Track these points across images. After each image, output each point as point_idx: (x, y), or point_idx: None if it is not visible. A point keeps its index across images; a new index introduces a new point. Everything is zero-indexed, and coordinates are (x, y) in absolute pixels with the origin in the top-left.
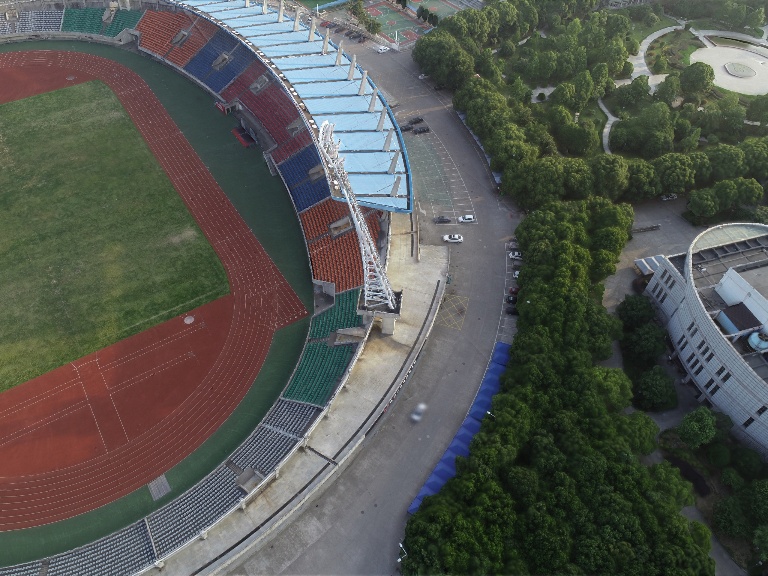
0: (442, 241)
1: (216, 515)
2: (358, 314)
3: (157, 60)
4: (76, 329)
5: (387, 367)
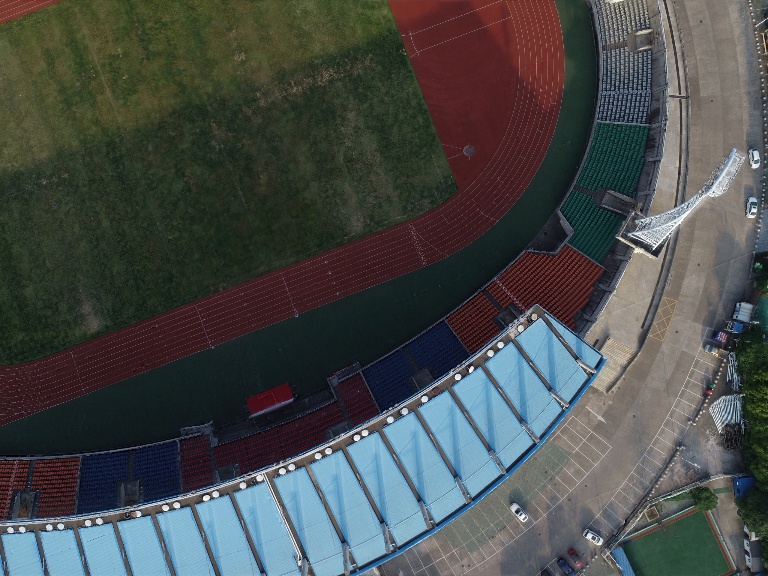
0: None
1: None
2: None
3: None
4: None
5: None
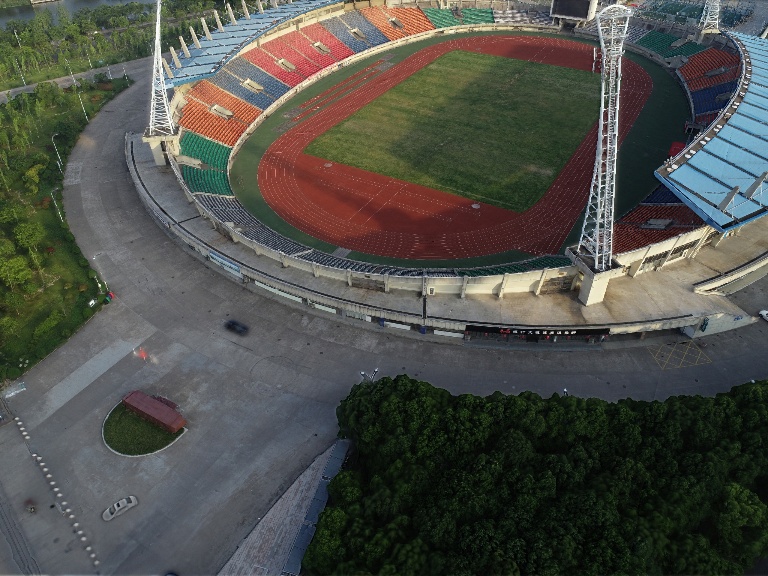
0: (756, 312)
1: None
2: (567, 256)
3: (681, 84)
4: (418, 168)
5: (547, 315)
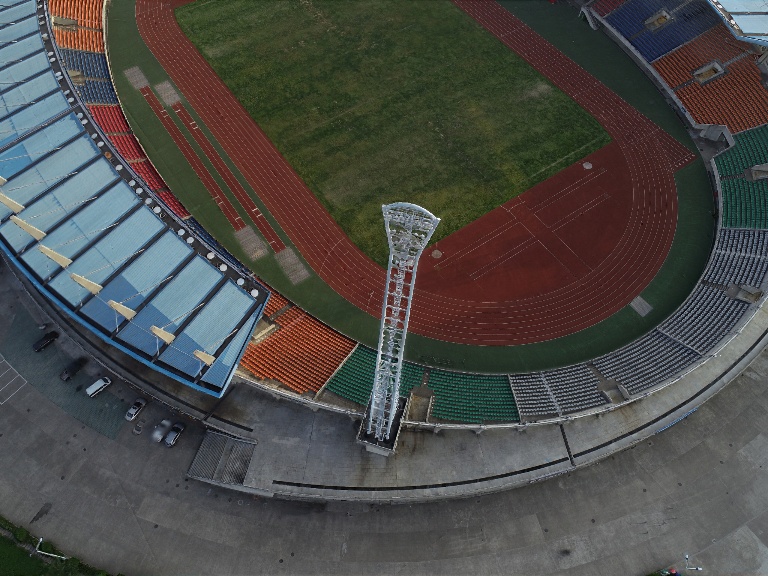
0: None
1: (732, 321)
2: None
3: None
4: (488, 177)
5: None
